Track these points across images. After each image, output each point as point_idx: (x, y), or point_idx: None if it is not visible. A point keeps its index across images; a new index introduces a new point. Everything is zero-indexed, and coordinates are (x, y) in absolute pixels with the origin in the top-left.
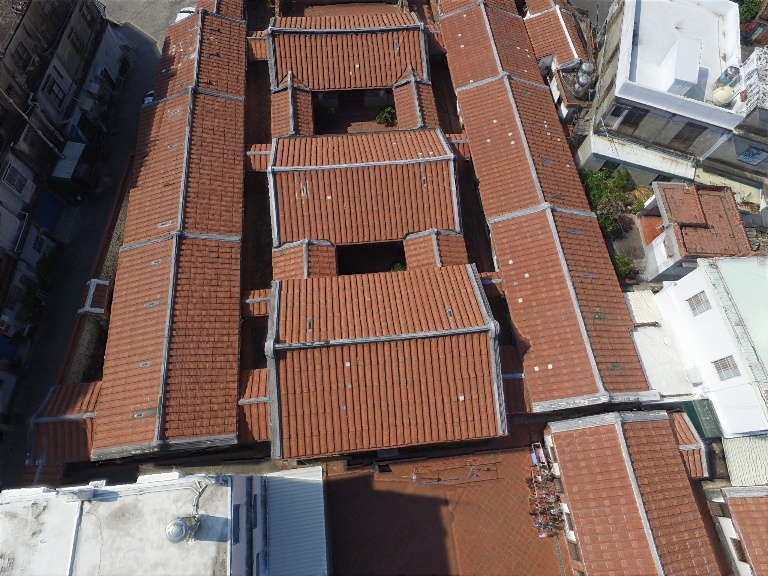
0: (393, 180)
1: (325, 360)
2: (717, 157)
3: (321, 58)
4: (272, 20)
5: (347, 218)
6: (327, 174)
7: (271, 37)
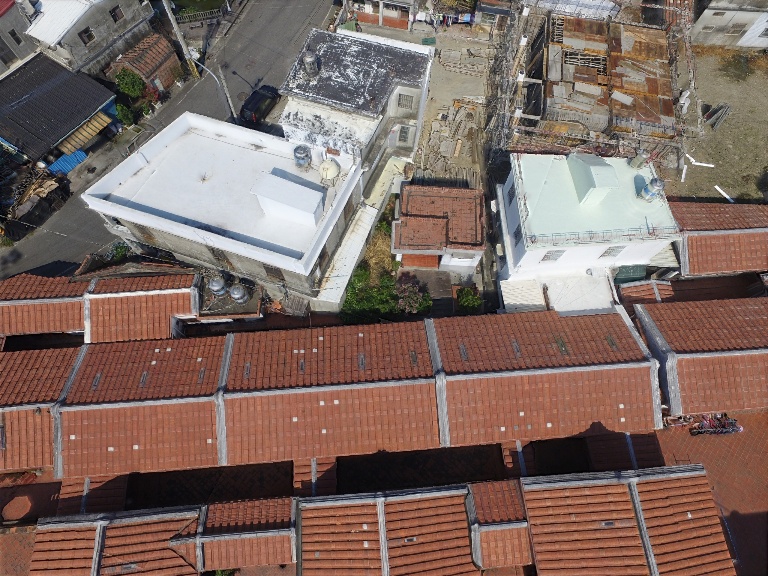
0: None
1: None
2: (365, 185)
3: None
4: None
5: None
6: None
7: None
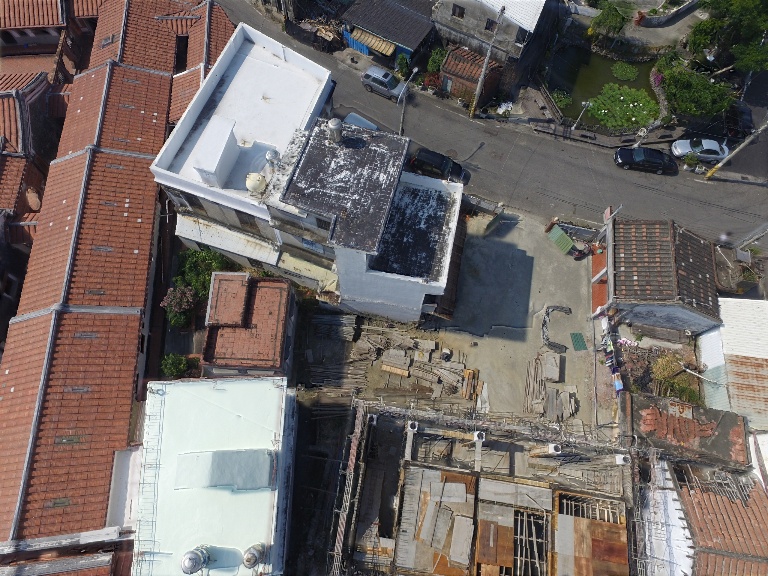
0: None
1: None
2: (290, 243)
3: None
4: None
5: None
6: None
7: None
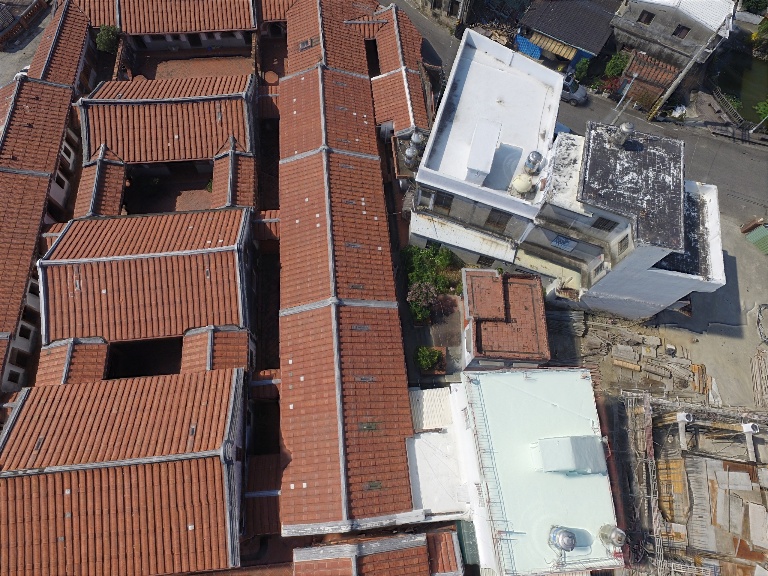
0: (174, 272)
1: (43, 487)
2: (533, 241)
3: (138, 129)
4: (97, 86)
5: (123, 313)
6: (102, 267)
7: (83, 108)
